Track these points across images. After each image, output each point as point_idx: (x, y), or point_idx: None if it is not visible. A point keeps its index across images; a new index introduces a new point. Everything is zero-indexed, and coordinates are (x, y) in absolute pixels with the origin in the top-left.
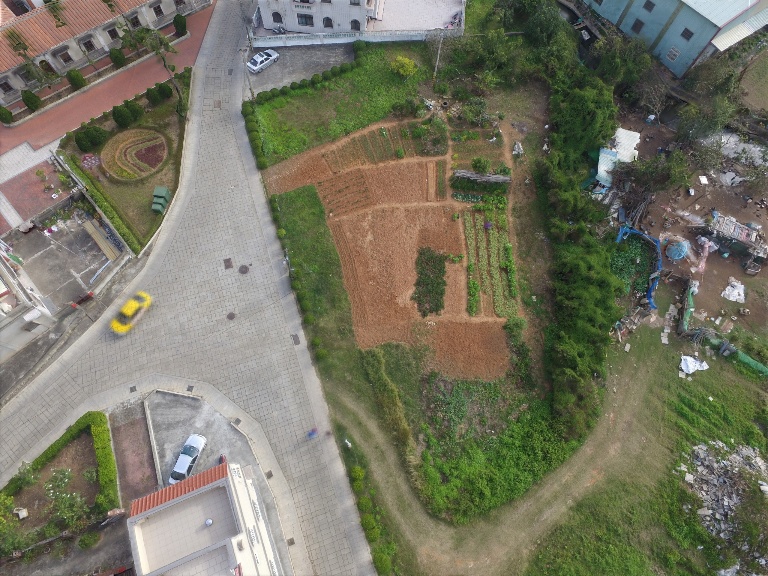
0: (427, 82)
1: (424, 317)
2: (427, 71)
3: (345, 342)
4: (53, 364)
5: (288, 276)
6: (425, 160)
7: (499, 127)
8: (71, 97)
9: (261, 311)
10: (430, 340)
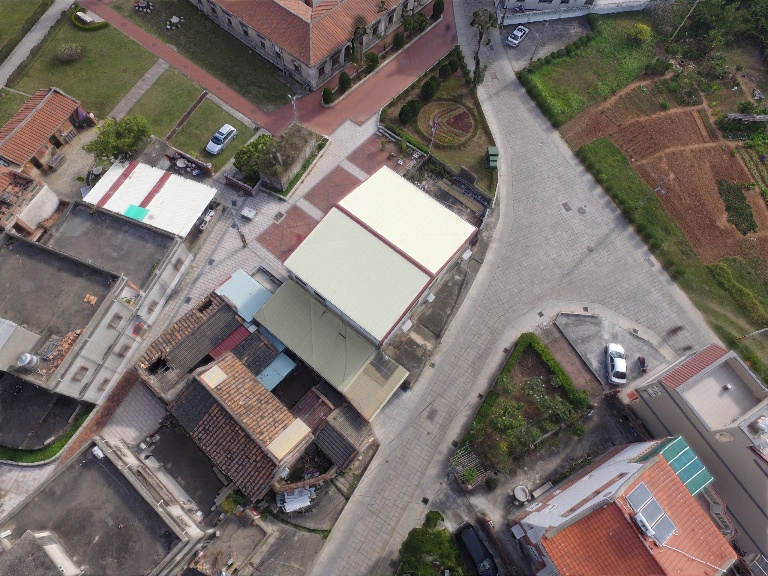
0: (659, 45)
1: (745, 235)
2: (656, 36)
3: (691, 260)
4: (465, 301)
5: (620, 213)
6: (688, 109)
7: (737, 78)
8: (369, 78)
9: (612, 243)
10: (758, 252)
